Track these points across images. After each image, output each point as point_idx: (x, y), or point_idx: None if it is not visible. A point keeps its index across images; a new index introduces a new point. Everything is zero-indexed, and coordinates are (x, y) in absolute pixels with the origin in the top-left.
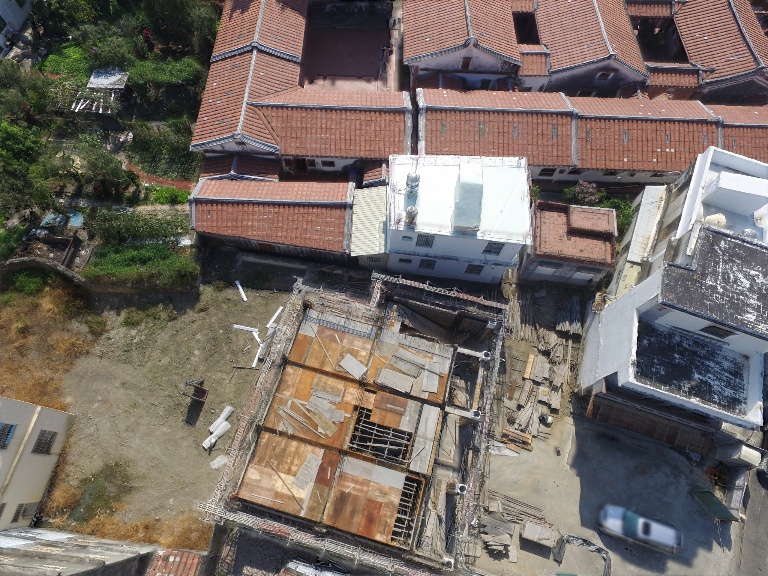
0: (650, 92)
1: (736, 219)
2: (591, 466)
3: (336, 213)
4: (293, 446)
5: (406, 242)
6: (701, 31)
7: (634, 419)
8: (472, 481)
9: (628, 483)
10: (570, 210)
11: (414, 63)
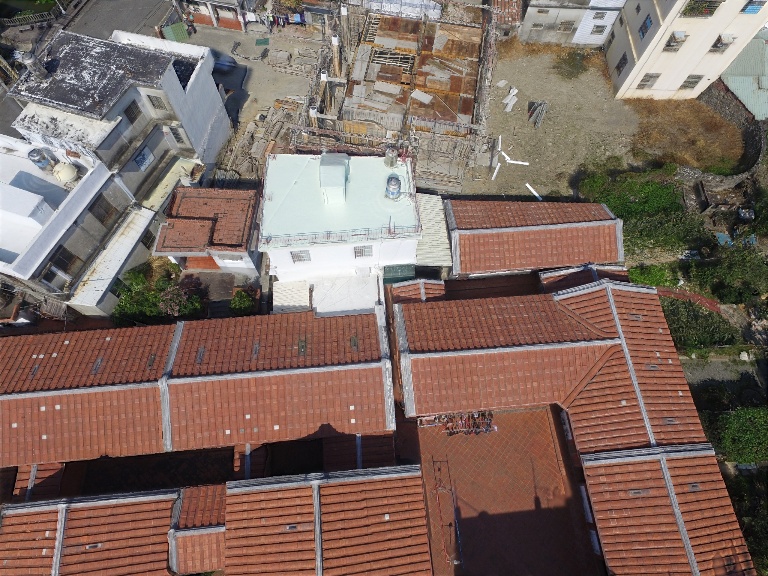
0: None
1: None
2: (231, 95)
3: (466, 225)
4: (454, 53)
5: None
6: None
7: None
8: None
9: None
10: (206, 248)
11: None
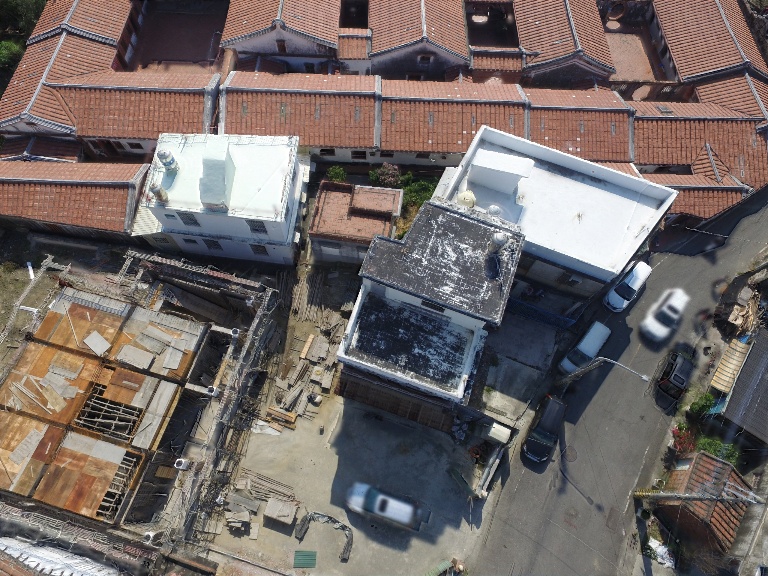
0: (478, 76)
1: (498, 197)
2: (352, 445)
3: (119, 193)
4: (18, 422)
5: (173, 221)
6: (534, 16)
7: (379, 396)
8: (227, 459)
9: (387, 461)
10: (357, 190)
11: (229, 46)
